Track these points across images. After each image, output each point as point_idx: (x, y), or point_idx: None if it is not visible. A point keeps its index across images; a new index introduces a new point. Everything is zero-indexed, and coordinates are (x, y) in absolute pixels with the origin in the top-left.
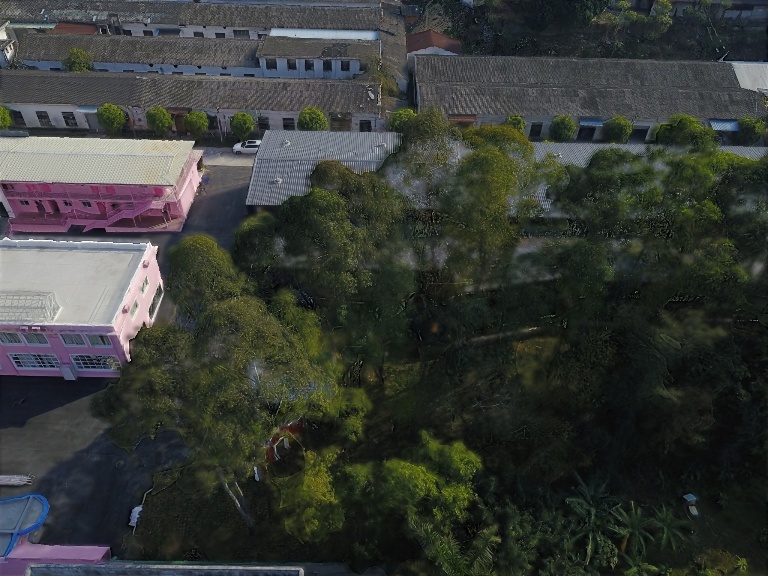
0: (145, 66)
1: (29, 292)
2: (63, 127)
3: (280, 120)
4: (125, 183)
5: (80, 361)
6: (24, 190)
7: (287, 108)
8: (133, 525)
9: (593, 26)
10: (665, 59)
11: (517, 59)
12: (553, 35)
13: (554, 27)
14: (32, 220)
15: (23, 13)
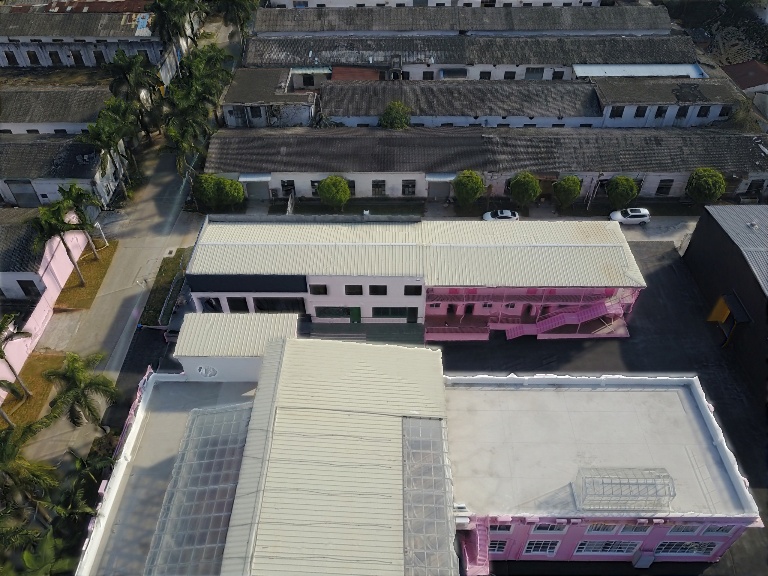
0: (468, 118)
1: (636, 470)
2: (397, 196)
3: (656, 182)
4: (586, 285)
5: (664, 546)
6: (444, 292)
7: (671, 169)
8: None
9: None
10: None
11: None
12: None
13: None
14: (455, 328)
15: (290, 56)
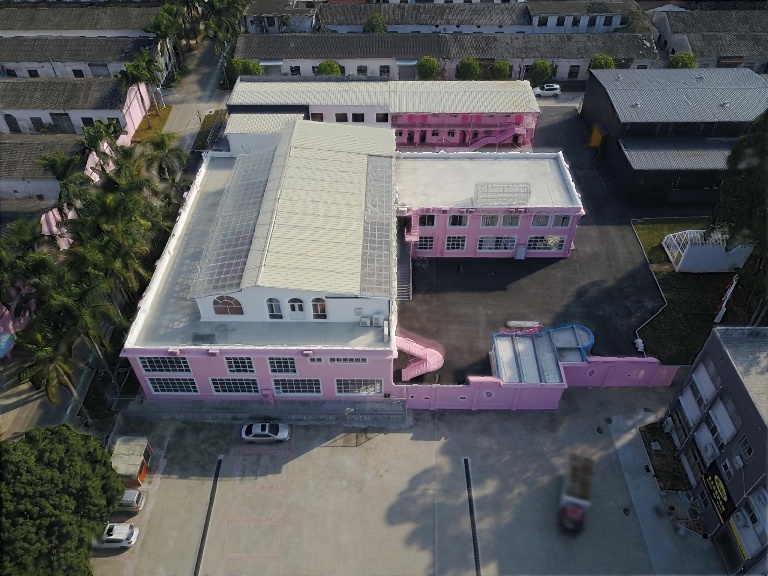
0: (431, 27)
1: None
2: None
3: (567, 67)
4: (499, 112)
5: (532, 242)
6: (404, 122)
7: (577, 56)
8: (642, 351)
9: None
10: None
11: (756, 11)
12: None
13: None
14: (411, 147)
15: None
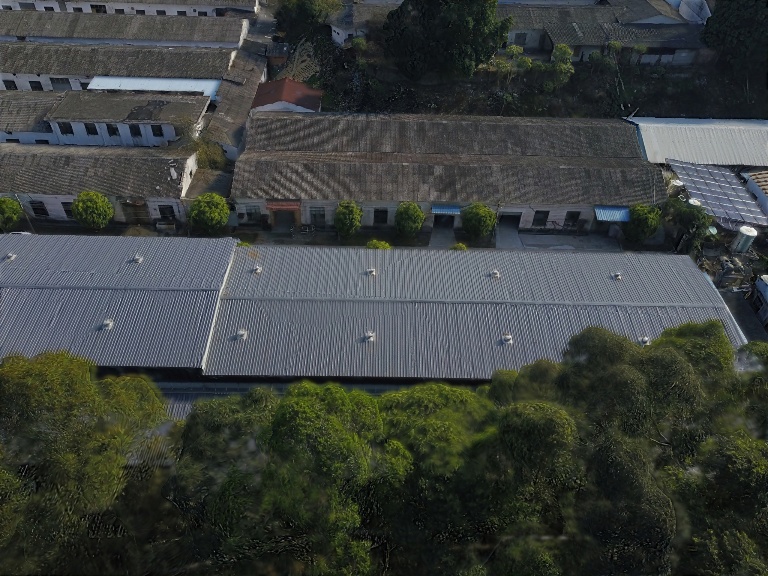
0: None
1: None
2: None
3: (59, 204)
4: None
5: None
6: None
7: (63, 191)
8: None
9: (482, 74)
10: (567, 114)
11: (373, 121)
12: (434, 84)
13: (435, 75)
14: None
15: None
